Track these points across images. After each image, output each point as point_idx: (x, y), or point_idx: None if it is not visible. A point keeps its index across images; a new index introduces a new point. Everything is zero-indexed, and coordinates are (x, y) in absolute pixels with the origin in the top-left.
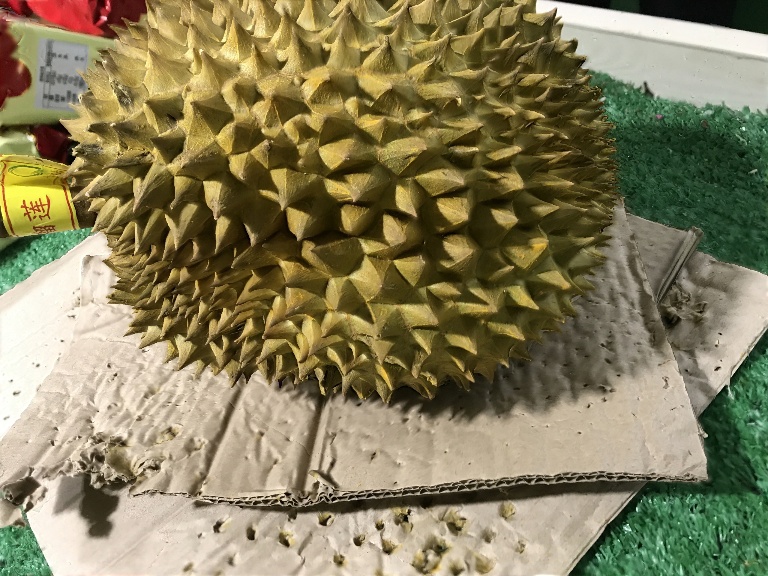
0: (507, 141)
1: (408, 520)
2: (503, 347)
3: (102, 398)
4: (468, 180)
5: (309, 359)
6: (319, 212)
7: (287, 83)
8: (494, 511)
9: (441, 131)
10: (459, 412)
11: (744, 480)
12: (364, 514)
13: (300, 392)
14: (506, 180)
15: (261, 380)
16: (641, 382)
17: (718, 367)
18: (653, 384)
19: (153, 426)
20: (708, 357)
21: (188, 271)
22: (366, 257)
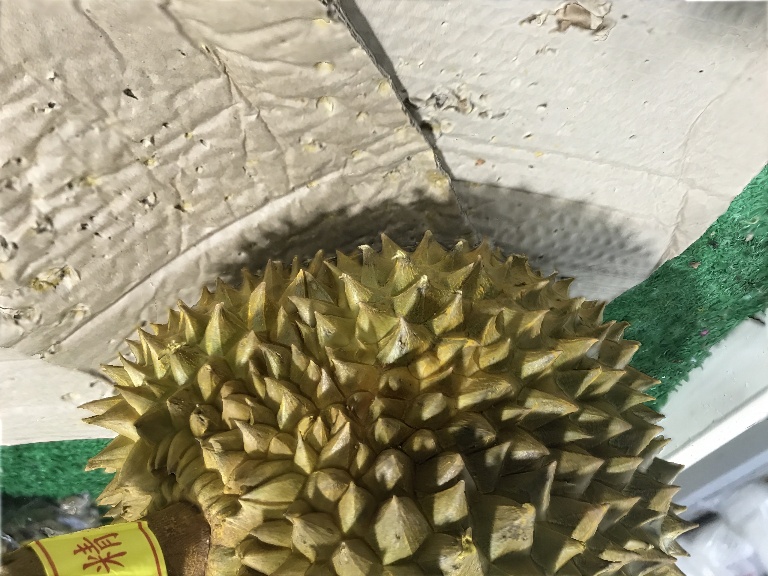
0: None
1: None
2: None
3: (4, 137)
4: None
5: None
6: None
7: None
8: None
9: None
10: None
11: None
12: None
13: None
14: None
15: (204, 267)
16: None
17: None
18: None
19: (47, 254)
20: None
21: None
22: None
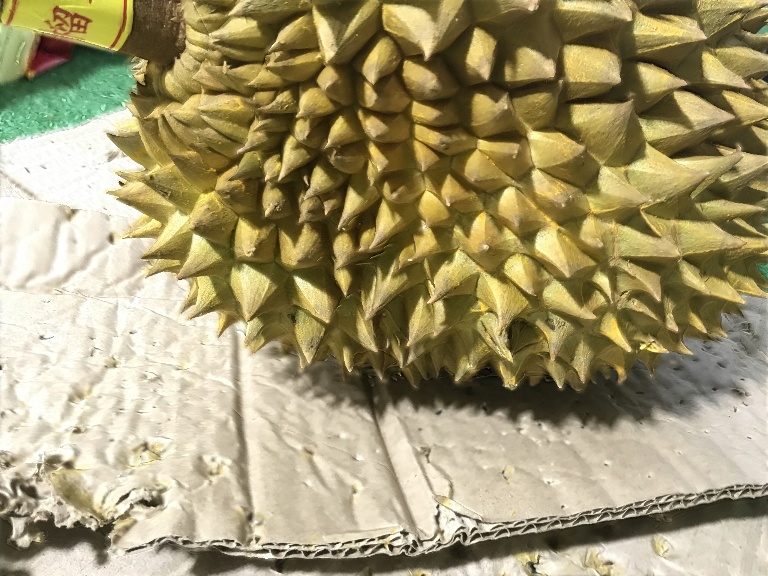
0: None
1: (537, 571)
2: (719, 312)
3: None
4: None
5: (515, 299)
6: (621, 59)
7: None
8: (647, 549)
9: None
10: (589, 418)
11: None
12: (478, 567)
13: (338, 398)
14: None
15: (269, 382)
16: None
17: None
18: None
19: (113, 440)
20: None
21: (383, 121)
22: (648, 145)
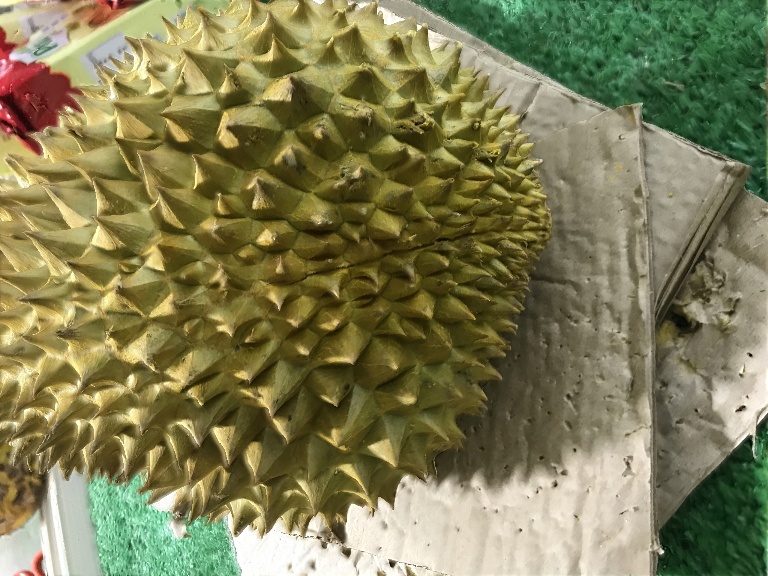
0: (256, 344)
1: None
2: (382, 491)
3: None
4: (225, 412)
5: None
6: None
7: (30, 382)
8: None
9: (167, 385)
10: None
11: (750, 575)
12: None
13: None
14: (262, 400)
15: None
16: (596, 465)
17: (742, 406)
18: (610, 469)
19: None
20: (728, 392)
21: None
22: None
